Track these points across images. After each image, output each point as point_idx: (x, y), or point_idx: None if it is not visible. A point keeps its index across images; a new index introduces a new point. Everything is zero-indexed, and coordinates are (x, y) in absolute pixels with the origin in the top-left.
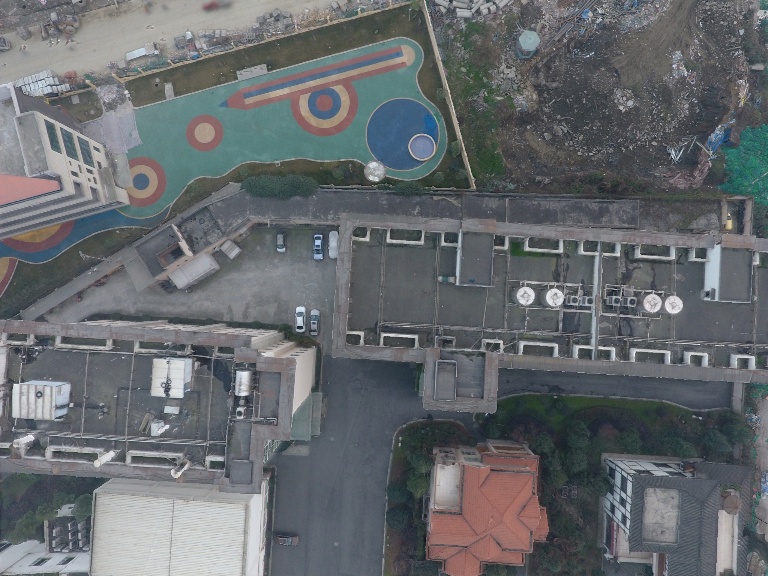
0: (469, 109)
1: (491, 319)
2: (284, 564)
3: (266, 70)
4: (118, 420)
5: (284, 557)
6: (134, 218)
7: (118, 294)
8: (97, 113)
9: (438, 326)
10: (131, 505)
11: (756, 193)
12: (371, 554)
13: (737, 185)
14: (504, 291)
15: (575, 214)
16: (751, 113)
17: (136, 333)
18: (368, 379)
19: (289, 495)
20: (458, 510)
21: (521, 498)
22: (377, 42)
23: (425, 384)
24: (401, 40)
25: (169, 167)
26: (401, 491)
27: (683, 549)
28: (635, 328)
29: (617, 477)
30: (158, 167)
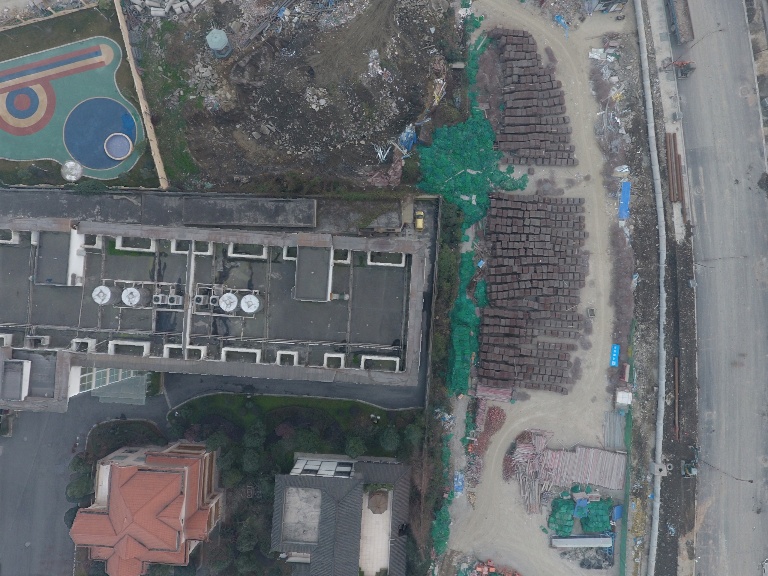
0: (166, 108)
1: (87, 318)
2: None
3: None
4: None
5: None
6: None
7: None
8: None
9: (31, 325)
10: None
11: (449, 192)
12: None
13: (431, 184)
14: None
15: (251, 213)
16: (445, 112)
17: None
18: None
19: None
20: (106, 510)
21: (162, 498)
22: (75, 41)
23: None
24: (100, 39)
25: None
26: None
27: (321, 549)
28: (231, 327)
29: None
30: None
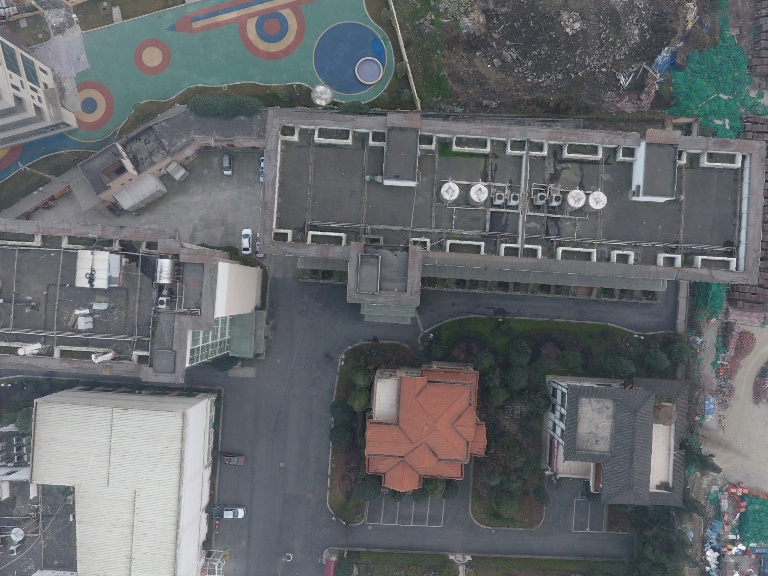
0: (416, 32)
1: (419, 219)
2: (231, 484)
3: None
4: (47, 316)
5: (231, 477)
6: (82, 142)
7: (66, 217)
8: (45, 37)
9: (366, 225)
10: (71, 414)
11: (703, 116)
12: (317, 474)
13: (684, 108)
14: (432, 191)
15: None
16: (699, 36)
17: (63, 227)
18: (314, 302)
19: (236, 416)
20: (395, 421)
21: (456, 407)
22: None
23: (349, 277)
24: None
25: (117, 91)
26: (343, 408)
27: (617, 458)
28: (563, 228)
29: (558, 395)
30: (106, 91)
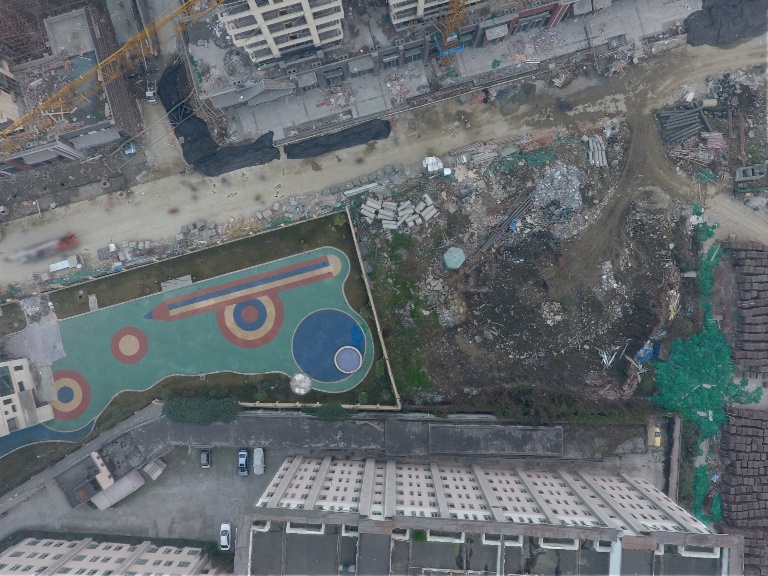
0: (396, 321)
1: None
2: None
3: (191, 281)
4: None
5: None
6: (59, 432)
7: (43, 509)
8: (21, 325)
9: None
10: None
11: (686, 408)
12: None
13: (667, 399)
14: None
15: (498, 442)
16: (681, 326)
17: None
18: None
19: None
20: None
21: None
22: (303, 252)
23: None
24: (327, 249)
25: (93, 380)
26: None
27: None
28: None
29: None
30: (82, 380)
